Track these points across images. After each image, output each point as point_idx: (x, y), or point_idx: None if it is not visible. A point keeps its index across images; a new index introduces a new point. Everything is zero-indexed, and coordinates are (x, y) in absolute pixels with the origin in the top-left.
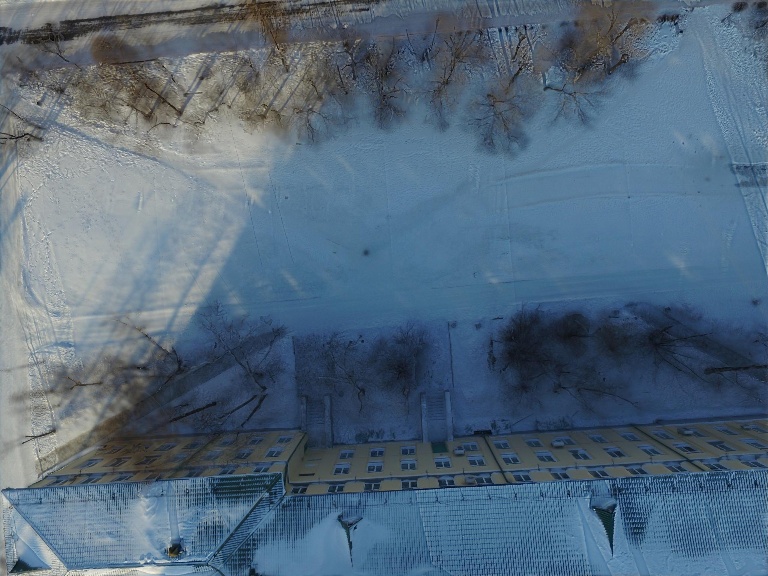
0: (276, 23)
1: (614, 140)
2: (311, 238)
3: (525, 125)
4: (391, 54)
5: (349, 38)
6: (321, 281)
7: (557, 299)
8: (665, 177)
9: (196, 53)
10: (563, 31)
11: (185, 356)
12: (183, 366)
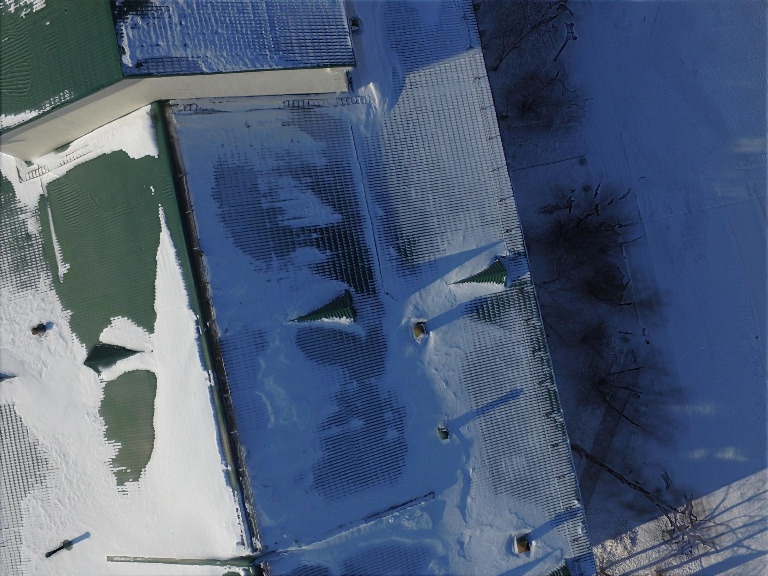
0: None
1: None
2: None
3: None
4: None
5: None
6: (611, 7)
7: (630, 272)
8: None
9: None
10: None
11: None
12: None
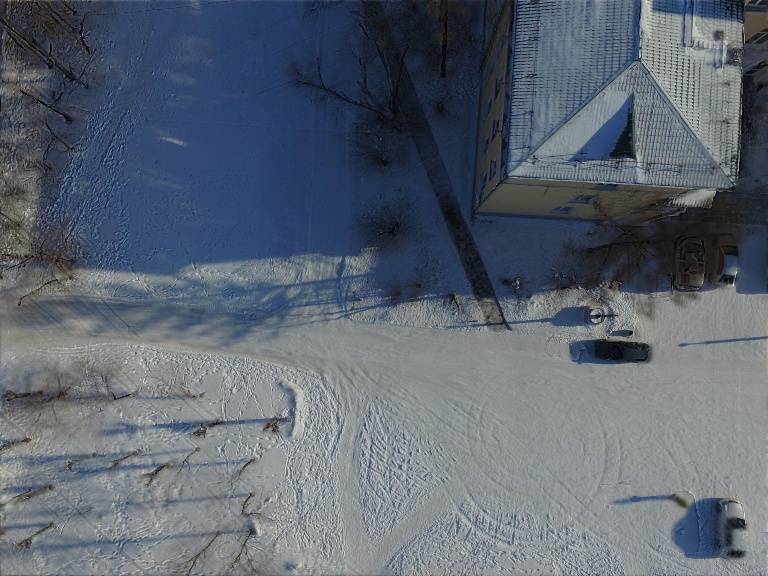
0: None
1: None
2: None
3: None
4: None
5: None
6: None
7: None
8: None
9: (1, 44)
10: None
11: None
12: None
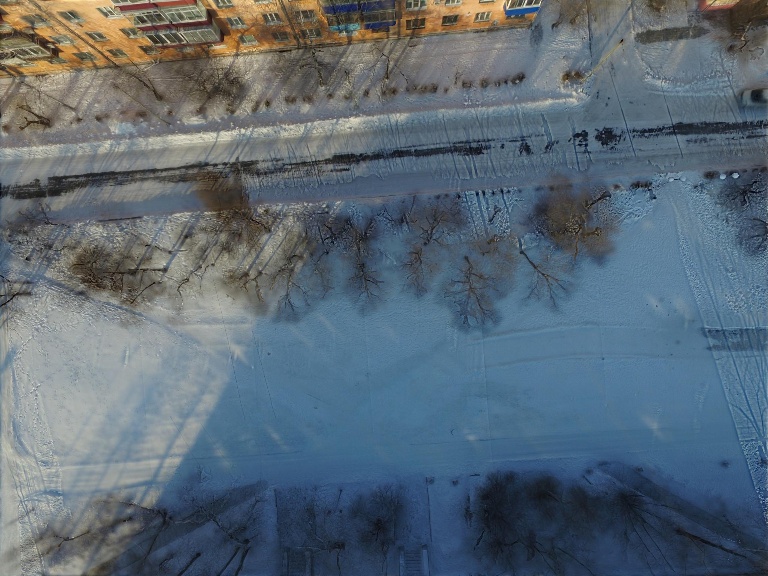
0: (259, 182)
1: (589, 302)
2: (293, 393)
3: (502, 286)
4: (370, 224)
5: (330, 198)
6: (303, 436)
7: (533, 458)
8: (639, 339)
9: (181, 212)
10: (539, 195)
11: (170, 508)
12: (168, 518)
